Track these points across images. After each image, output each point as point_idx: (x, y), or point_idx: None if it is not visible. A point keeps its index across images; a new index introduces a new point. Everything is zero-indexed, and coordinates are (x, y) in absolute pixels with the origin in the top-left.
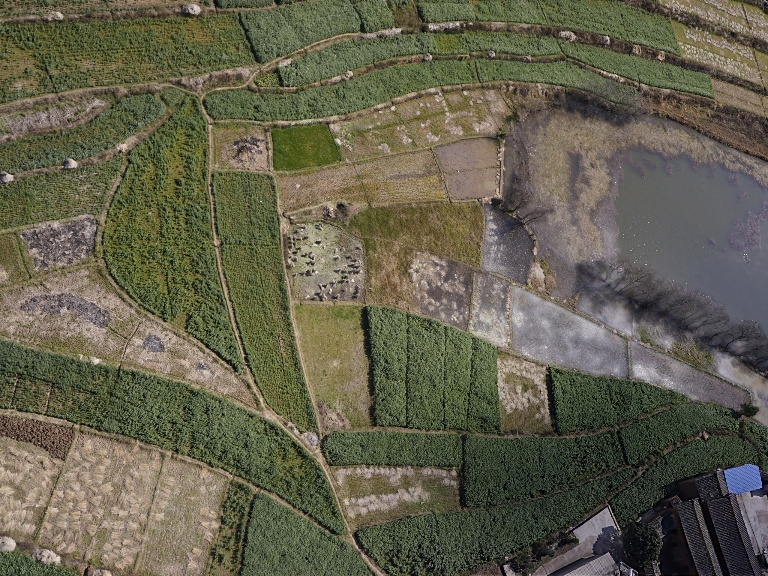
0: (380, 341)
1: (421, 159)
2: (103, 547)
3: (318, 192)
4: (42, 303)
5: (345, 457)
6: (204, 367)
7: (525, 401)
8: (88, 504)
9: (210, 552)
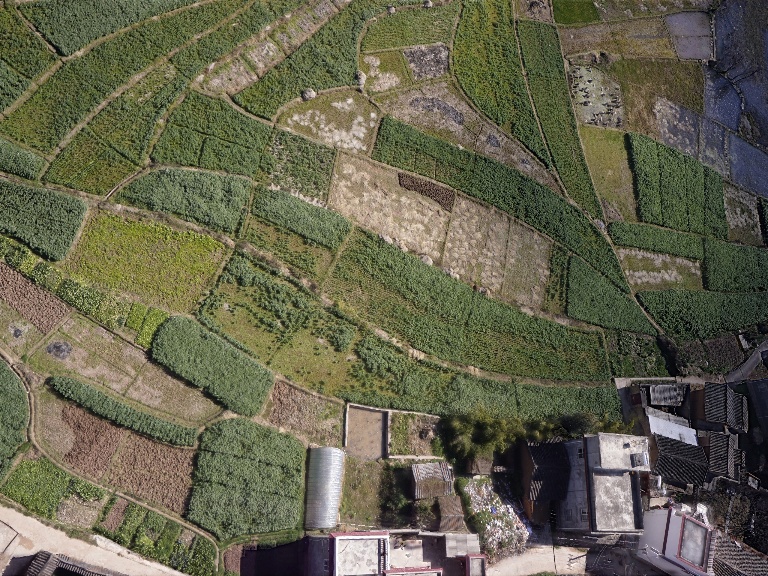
0: (641, 159)
1: (655, 24)
2: (481, 274)
3: (586, 43)
4: (422, 103)
5: (625, 240)
6: (526, 162)
7: (743, 221)
8: (468, 244)
9: (545, 290)
